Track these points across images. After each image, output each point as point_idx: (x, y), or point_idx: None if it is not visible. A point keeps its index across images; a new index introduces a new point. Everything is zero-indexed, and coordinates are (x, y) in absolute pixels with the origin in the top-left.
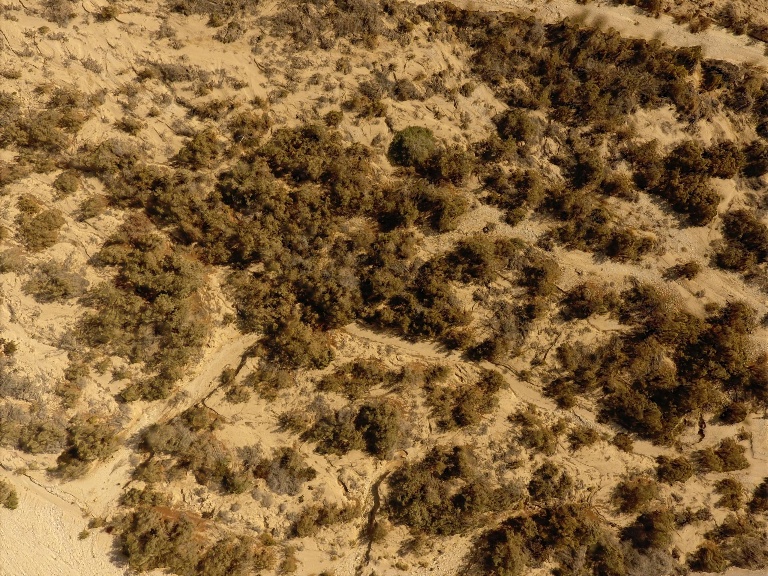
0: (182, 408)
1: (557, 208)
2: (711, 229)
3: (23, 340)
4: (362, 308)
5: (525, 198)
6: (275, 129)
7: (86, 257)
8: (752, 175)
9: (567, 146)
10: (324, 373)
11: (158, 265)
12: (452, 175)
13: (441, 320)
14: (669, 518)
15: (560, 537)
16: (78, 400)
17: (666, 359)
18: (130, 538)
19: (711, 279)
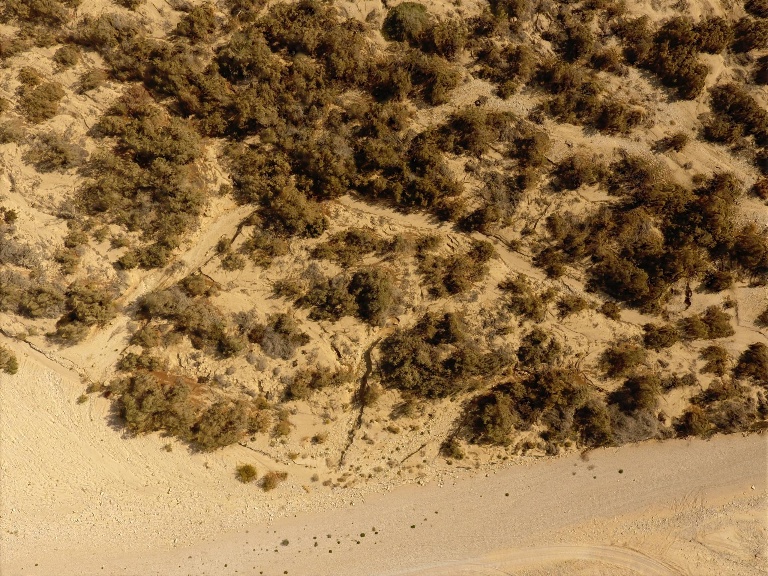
0: (179, 277)
1: (548, 80)
2: (699, 103)
3: (23, 209)
4: (356, 177)
5: (517, 72)
6: (271, 4)
7: (85, 129)
8: (740, 51)
9: (558, 21)
10: (318, 241)
11: (156, 132)
12: (445, 47)
13: (433, 187)
14: (655, 382)
15: (548, 396)
16: (77, 267)
17: (654, 229)
18: (127, 398)
19: (699, 151)
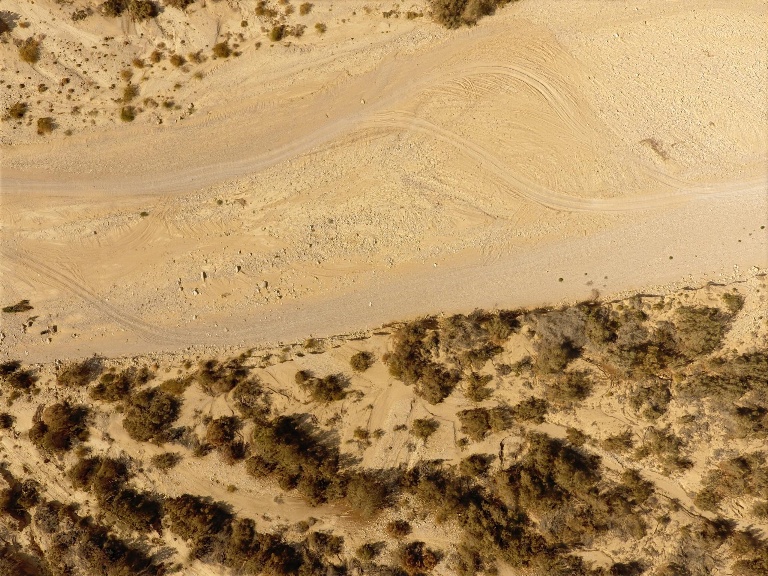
0: None
1: None
2: None
3: None
4: None
5: None
6: None
7: None
8: None
9: None
10: None
11: None
12: None
13: None
14: (538, 368)
15: None
16: None
17: (537, 521)
18: None
19: None
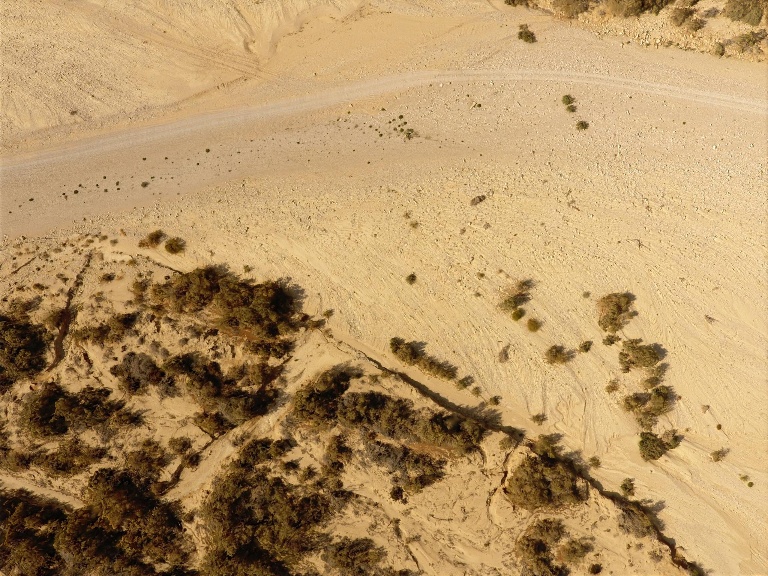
0: (238, 430)
1: None
2: None
3: (386, 501)
4: (57, 530)
5: None
6: None
7: None
8: None
9: None
10: (100, 465)
11: None
12: None
13: None
14: None
15: None
16: None
17: None
18: (273, 318)
19: None
